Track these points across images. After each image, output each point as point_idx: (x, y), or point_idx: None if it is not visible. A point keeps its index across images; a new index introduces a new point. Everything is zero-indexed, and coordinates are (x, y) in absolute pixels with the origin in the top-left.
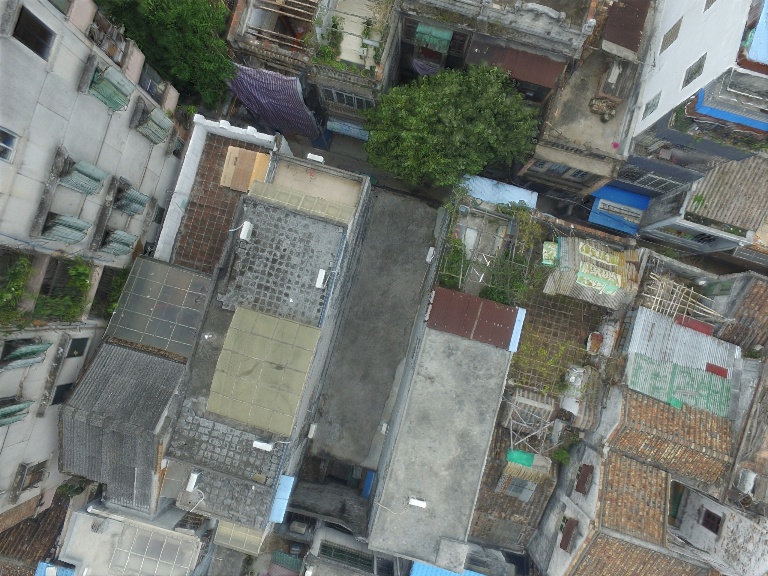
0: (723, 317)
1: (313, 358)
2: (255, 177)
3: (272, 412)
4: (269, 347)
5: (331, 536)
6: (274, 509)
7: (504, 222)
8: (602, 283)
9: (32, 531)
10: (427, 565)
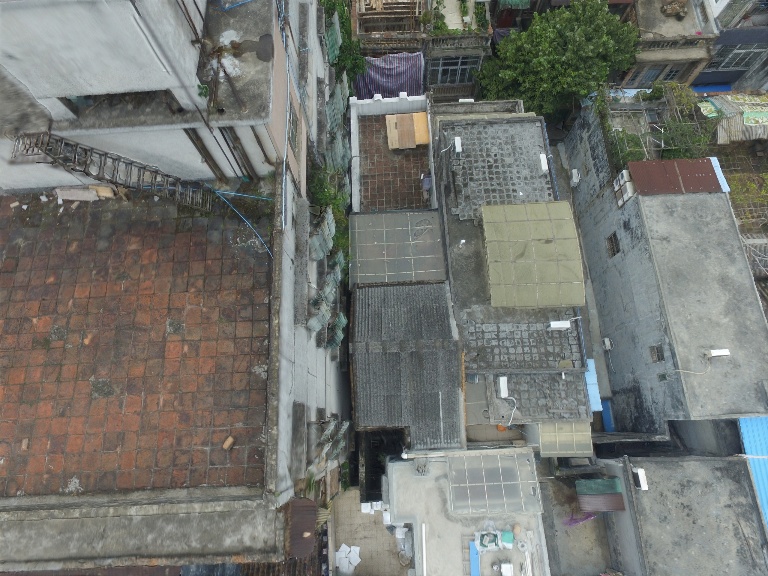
0: None
1: None
2: (418, 133)
3: (559, 285)
4: (530, 227)
5: (616, 459)
6: (590, 397)
7: (641, 114)
8: (767, 118)
9: (291, 569)
10: (755, 423)
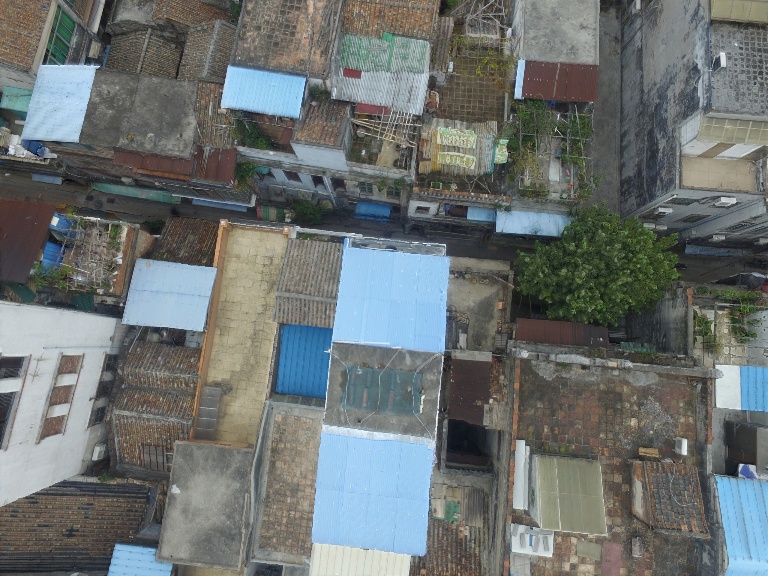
0: (350, 119)
1: (701, 7)
2: None
3: None
4: None
5: None
6: None
7: None
8: None
9: None
10: None
